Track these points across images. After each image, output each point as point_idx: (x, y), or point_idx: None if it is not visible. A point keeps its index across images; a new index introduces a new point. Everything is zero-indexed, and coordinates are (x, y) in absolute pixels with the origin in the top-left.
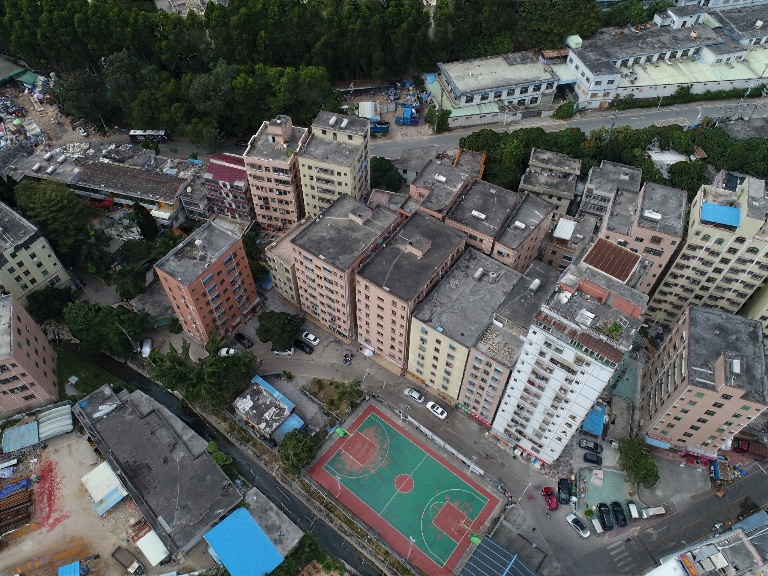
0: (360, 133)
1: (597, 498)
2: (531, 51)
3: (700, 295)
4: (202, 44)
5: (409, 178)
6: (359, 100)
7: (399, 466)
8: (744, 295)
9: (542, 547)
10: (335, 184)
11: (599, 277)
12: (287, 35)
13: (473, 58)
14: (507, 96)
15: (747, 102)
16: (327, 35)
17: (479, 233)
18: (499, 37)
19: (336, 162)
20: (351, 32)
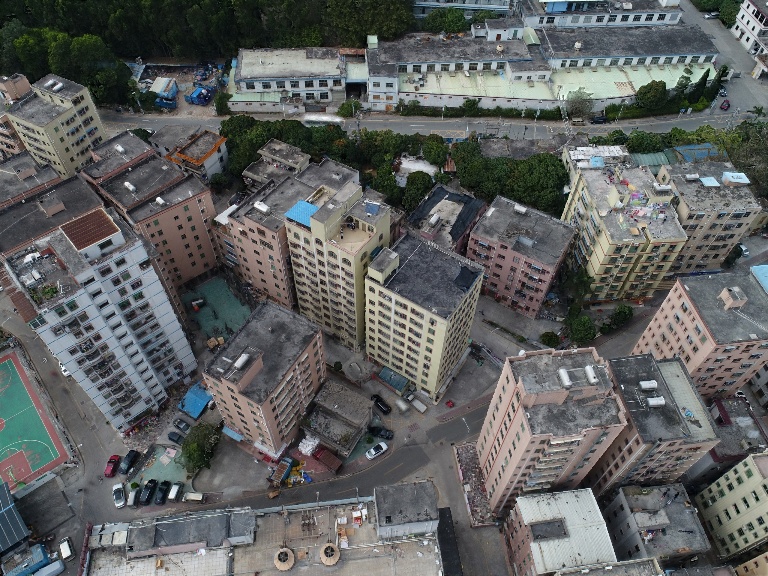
0: (68, 98)
1: (155, 474)
2: (338, 47)
3: (325, 298)
4: (15, 5)
5: (162, 153)
6: (169, 76)
7: (1, 410)
8: (351, 303)
9: (75, 507)
10: (41, 143)
11: (63, 243)
12: (88, 5)
13: (278, 48)
14: (292, 88)
15: (539, 124)
16: (124, 8)
17: (118, 203)
18: (309, 30)
19: (38, 122)
20: (143, 8)
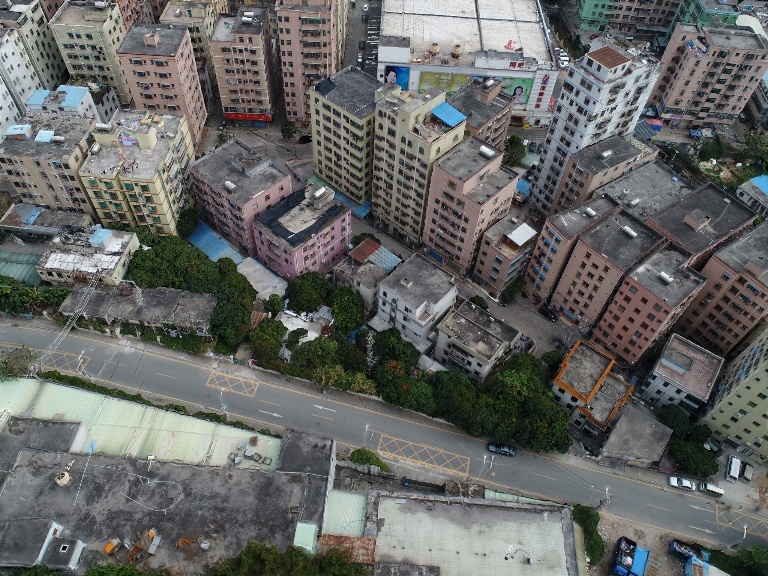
0: None
1: None
2: None
3: None
4: None
5: None
6: None
7: None
8: None
9: None
10: None
11: (622, 54)
12: None
13: None
14: None
15: None
16: None
17: None
18: None
19: None
20: None
